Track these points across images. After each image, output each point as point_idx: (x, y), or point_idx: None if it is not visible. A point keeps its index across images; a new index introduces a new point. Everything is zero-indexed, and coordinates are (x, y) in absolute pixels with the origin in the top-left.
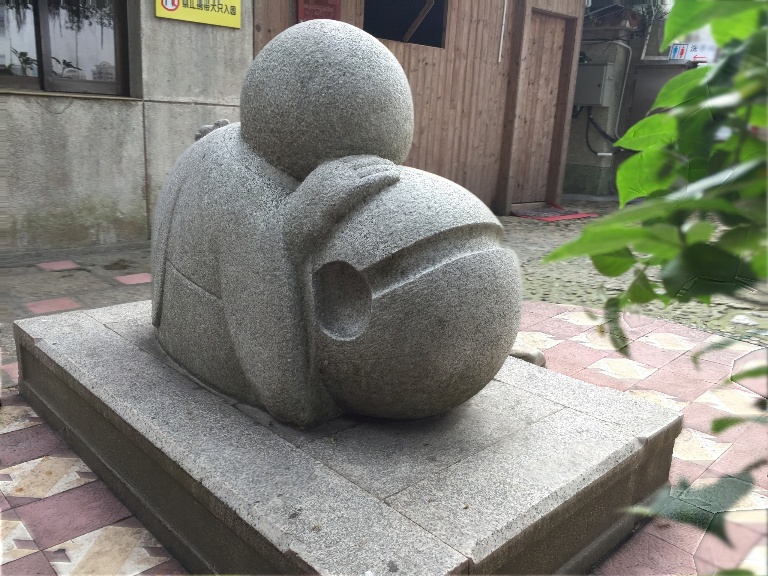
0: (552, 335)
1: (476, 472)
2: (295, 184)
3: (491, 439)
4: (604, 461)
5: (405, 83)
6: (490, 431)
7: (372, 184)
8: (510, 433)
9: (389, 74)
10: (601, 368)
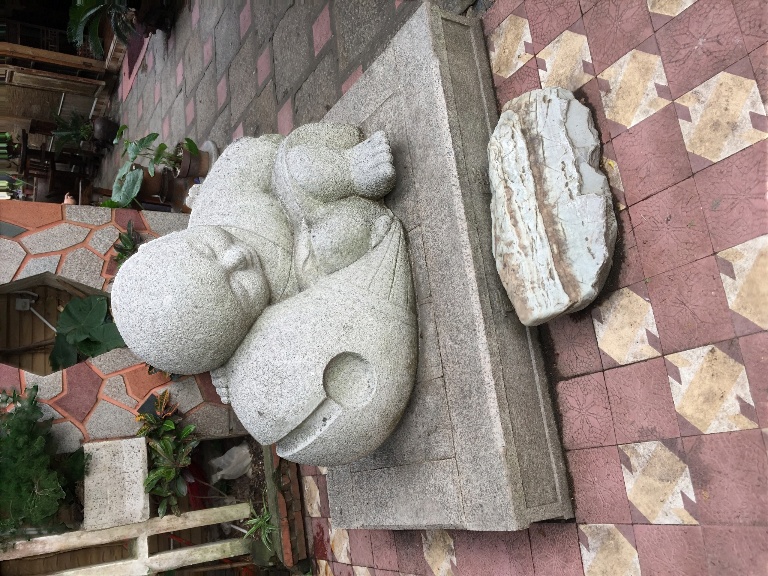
0: (763, 105)
1: (381, 483)
2: None
3: (402, 460)
4: (431, 525)
5: (172, 351)
6: (405, 451)
7: None
8: (412, 461)
9: (161, 364)
10: (734, 266)
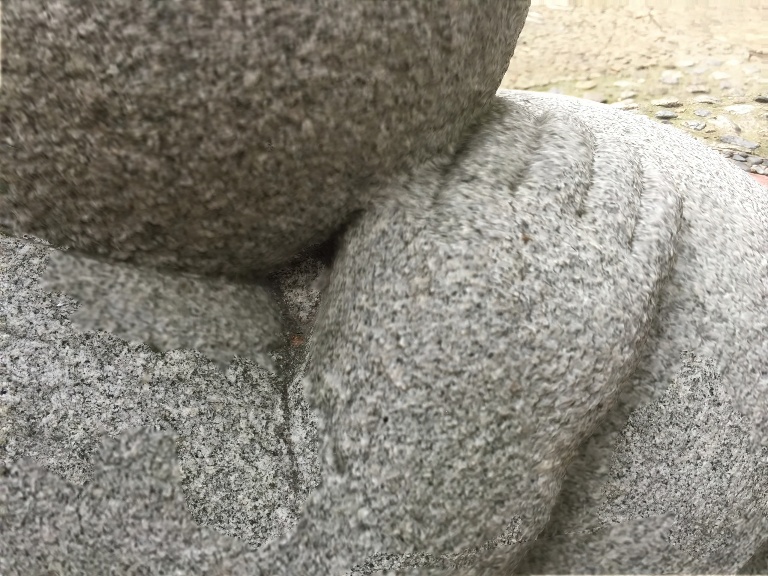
0: None
1: None
2: (257, 310)
3: None
4: None
5: None
6: None
7: (671, 259)
8: None
9: None
10: None
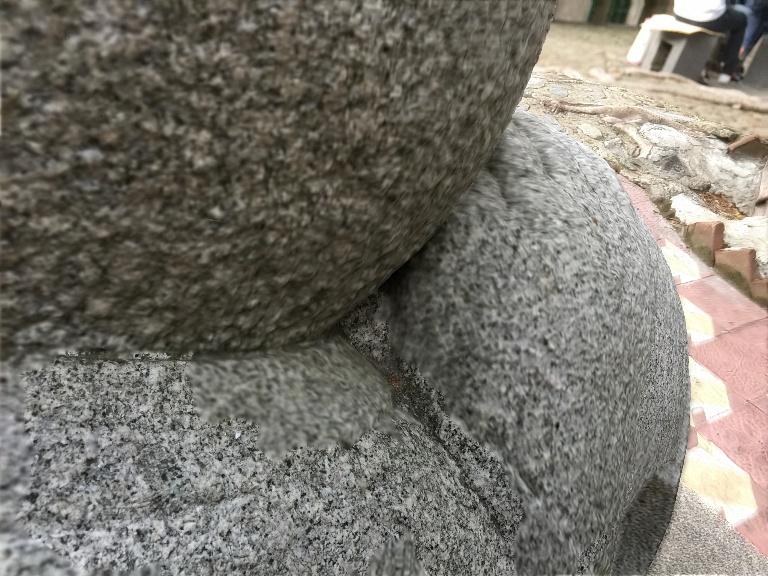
0: None
1: None
2: (362, 362)
3: None
4: None
5: None
6: None
7: None
8: None
9: None
10: None
